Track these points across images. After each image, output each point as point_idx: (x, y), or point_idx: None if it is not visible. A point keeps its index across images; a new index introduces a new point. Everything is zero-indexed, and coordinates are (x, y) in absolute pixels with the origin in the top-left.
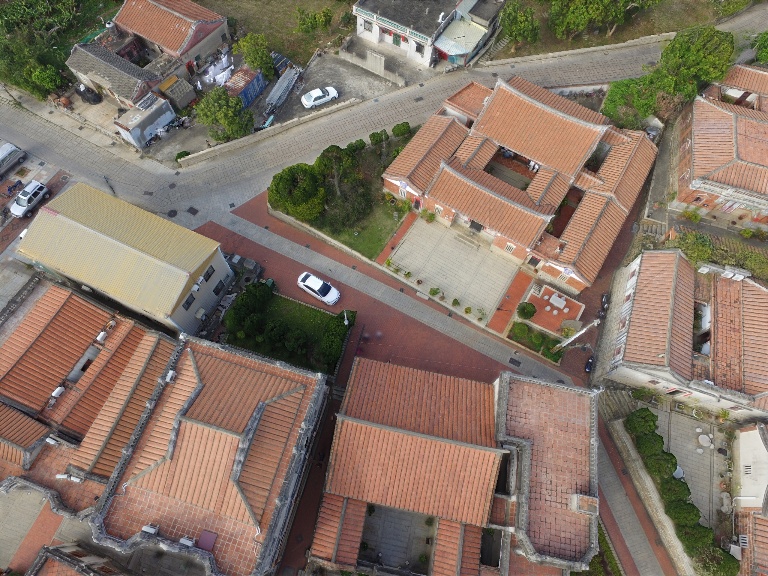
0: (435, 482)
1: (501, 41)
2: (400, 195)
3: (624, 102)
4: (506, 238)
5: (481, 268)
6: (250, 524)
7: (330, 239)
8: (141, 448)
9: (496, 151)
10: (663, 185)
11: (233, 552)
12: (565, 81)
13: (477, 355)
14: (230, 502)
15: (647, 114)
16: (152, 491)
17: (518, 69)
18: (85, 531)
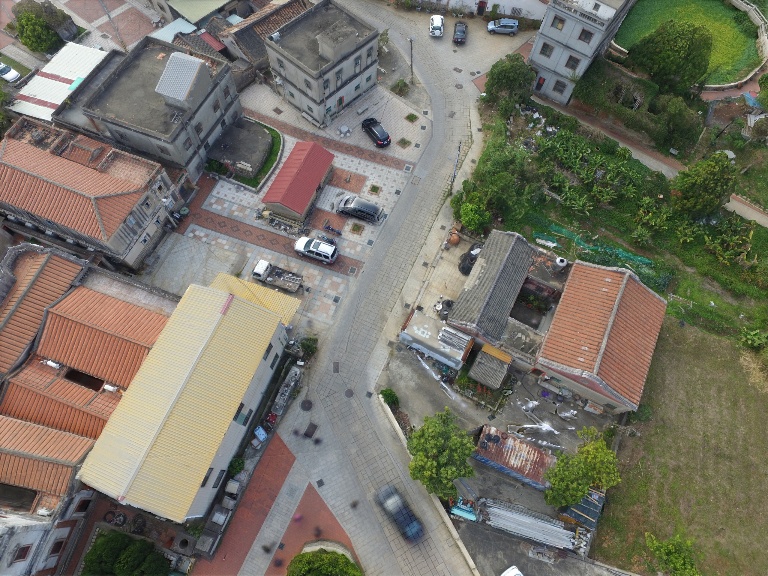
0: None
1: None
2: None
3: None
4: None
5: None
6: None
7: None
8: None
9: None
10: None
11: None
12: None
13: None
14: None
15: None
16: None
17: None
18: None
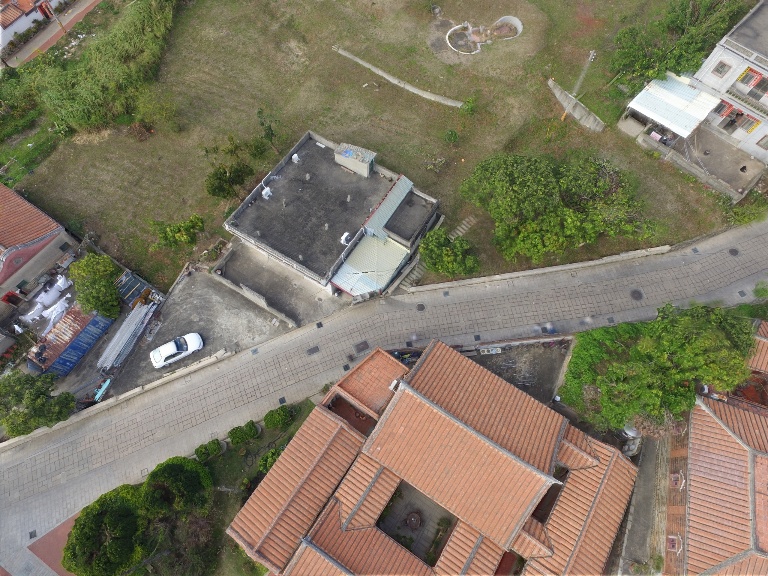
0: None
1: None
2: None
3: (592, 379)
4: None
5: None
6: None
7: None
8: None
9: (398, 484)
10: (645, 525)
11: None
12: (515, 322)
13: None
14: None
15: (622, 426)
16: None
17: (453, 298)
18: None
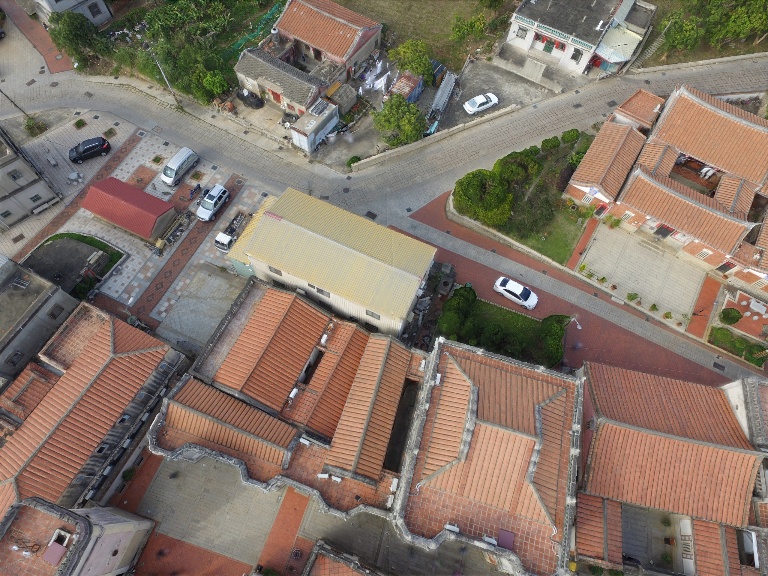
0: (693, 484)
1: (649, 48)
2: (583, 201)
3: None
4: (705, 245)
5: (670, 274)
6: (546, 524)
7: (518, 244)
8: (424, 449)
9: (677, 158)
10: None
11: (533, 551)
12: (719, 89)
13: (681, 359)
14: (525, 502)
15: None
16: (445, 491)
17: (670, 76)
18: (328, 529)
